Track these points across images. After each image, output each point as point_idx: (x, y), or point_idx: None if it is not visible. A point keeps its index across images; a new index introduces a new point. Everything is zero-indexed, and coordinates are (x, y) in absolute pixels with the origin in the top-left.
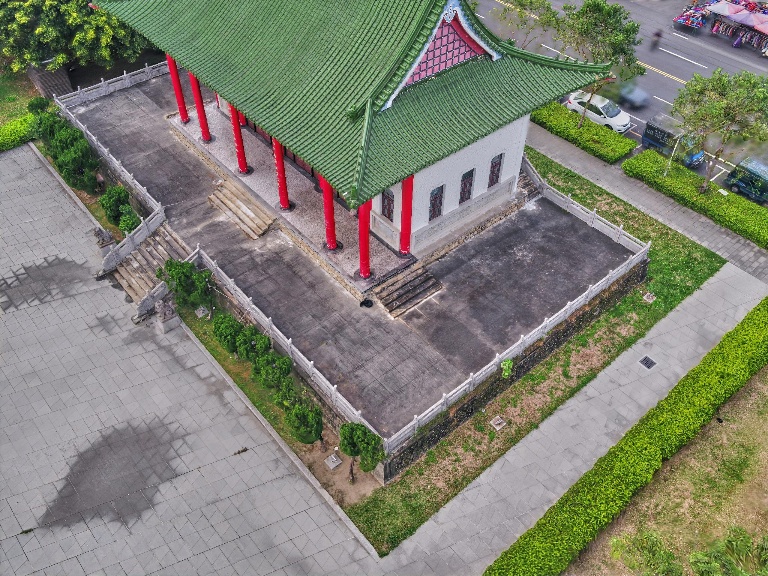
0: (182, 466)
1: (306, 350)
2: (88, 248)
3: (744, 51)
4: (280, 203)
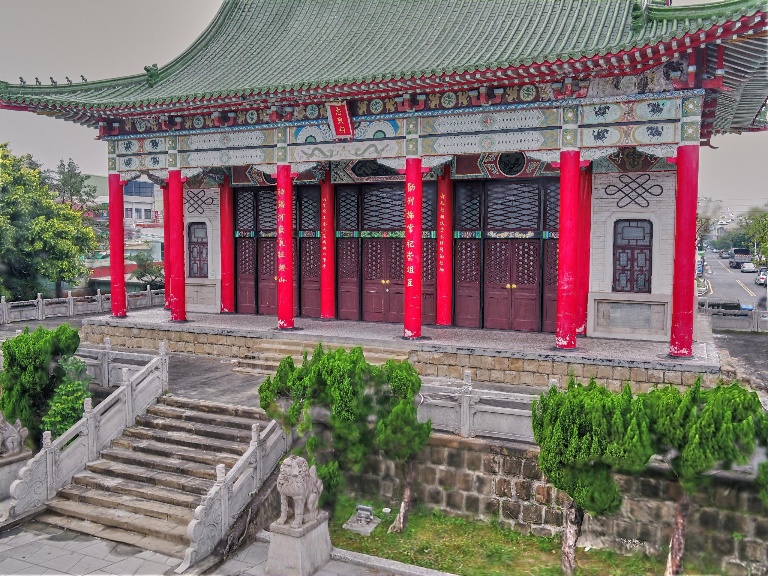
0: None
1: None
2: None
3: None
4: None
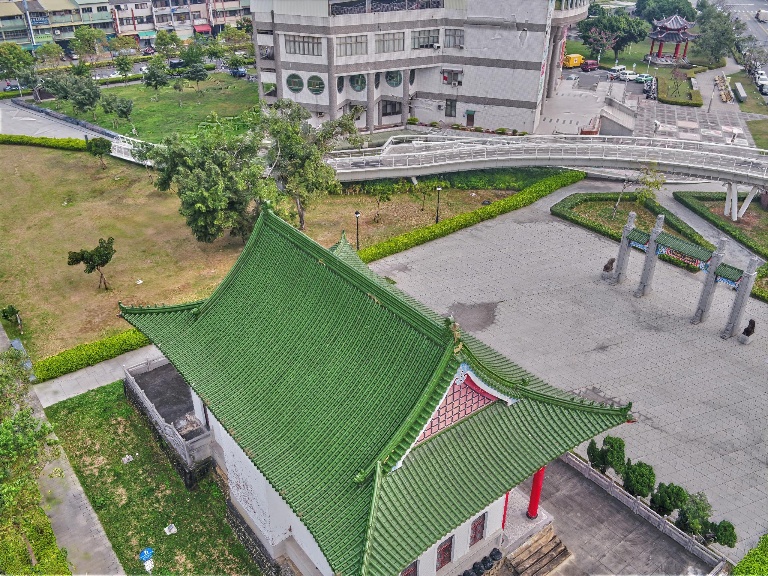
0: None
1: None
2: None
3: None
4: None
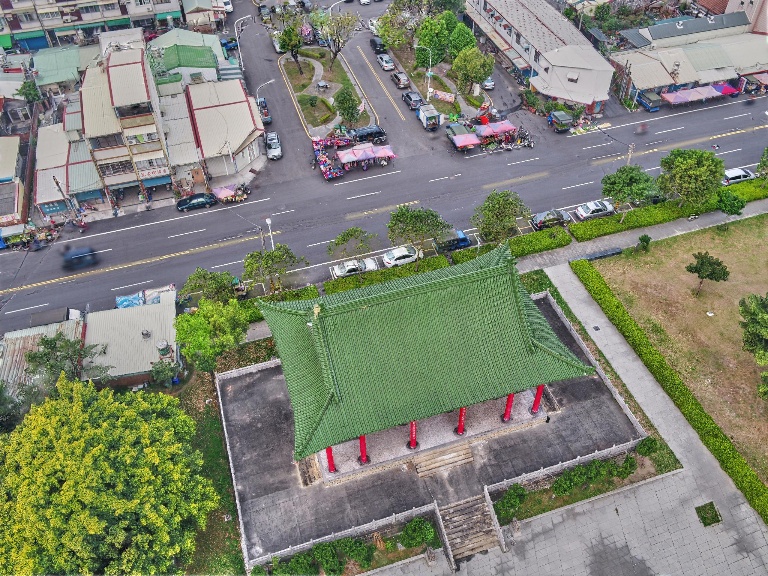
0: (621, 542)
1: (573, 457)
2: (422, 573)
3: (372, 169)
4: (458, 434)
